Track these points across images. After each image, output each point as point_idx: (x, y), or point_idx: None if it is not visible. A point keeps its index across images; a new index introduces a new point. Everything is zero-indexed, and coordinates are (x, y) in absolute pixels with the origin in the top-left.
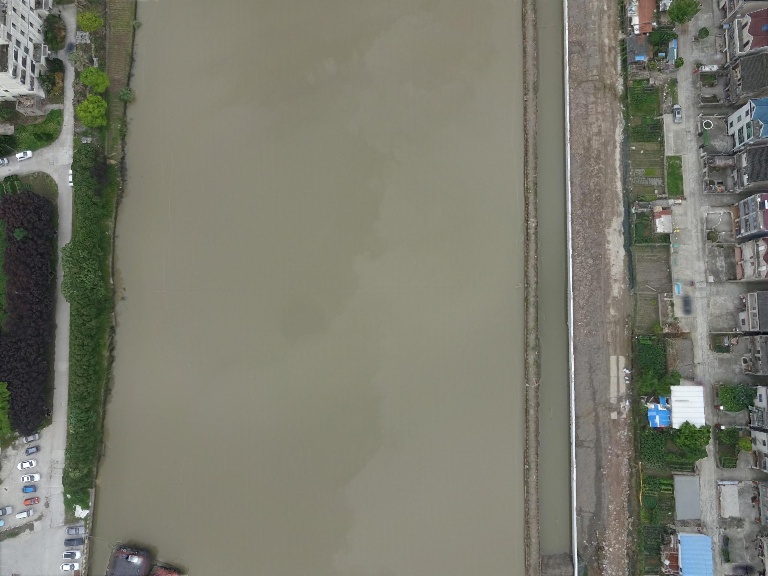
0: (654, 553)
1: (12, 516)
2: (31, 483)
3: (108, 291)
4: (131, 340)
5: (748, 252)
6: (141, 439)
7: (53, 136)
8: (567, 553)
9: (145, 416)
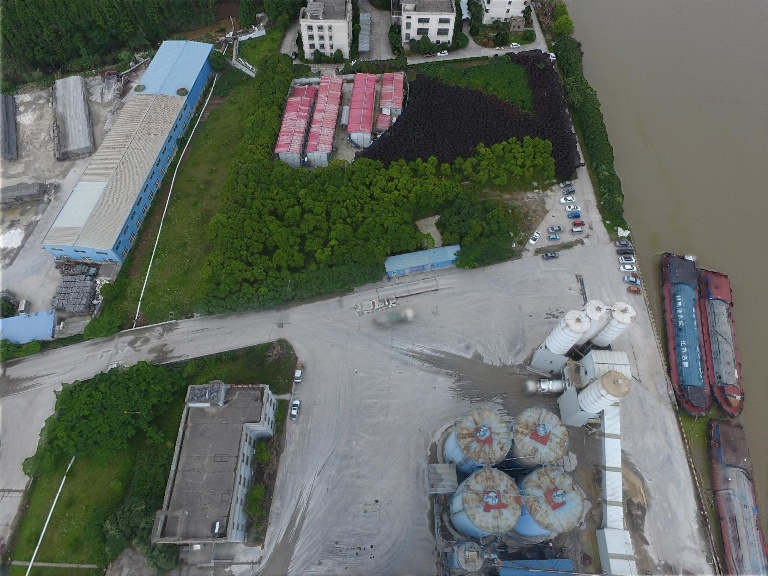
0: None
1: (563, 234)
2: (575, 211)
3: None
4: (616, 140)
5: None
6: (650, 192)
7: (532, 39)
8: None
9: (646, 181)
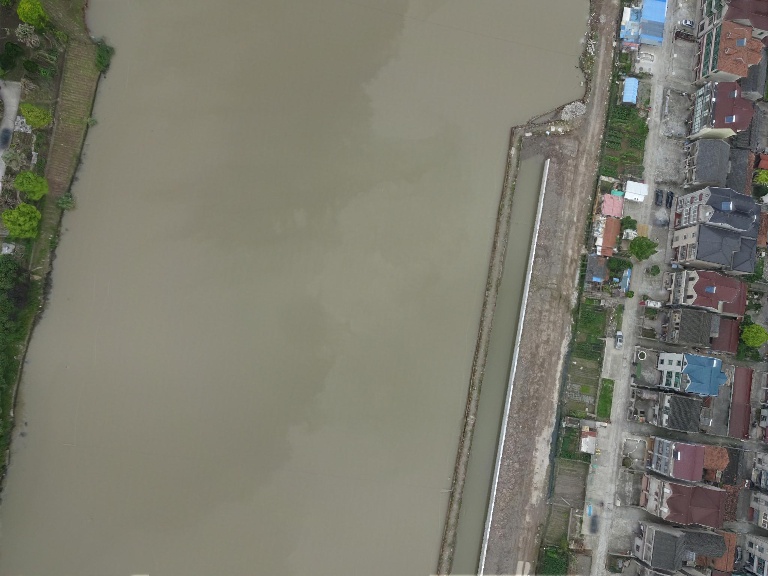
0: None
1: None
2: None
3: (6, 425)
4: (24, 483)
5: (654, 487)
6: None
7: None
8: None
9: (27, 571)
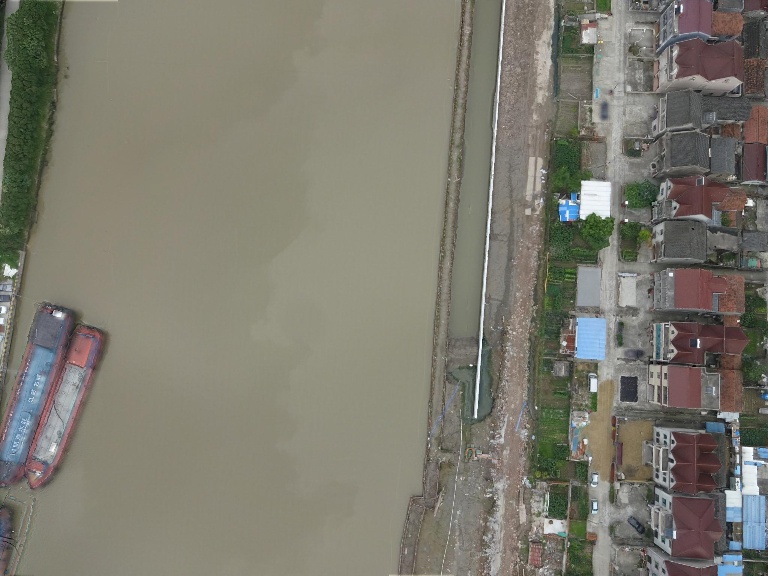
0: (554, 336)
1: None
2: None
3: (51, 67)
4: (71, 117)
5: (664, 62)
6: (74, 208)
7: None
8: (474, 337)
9: (80, 188)
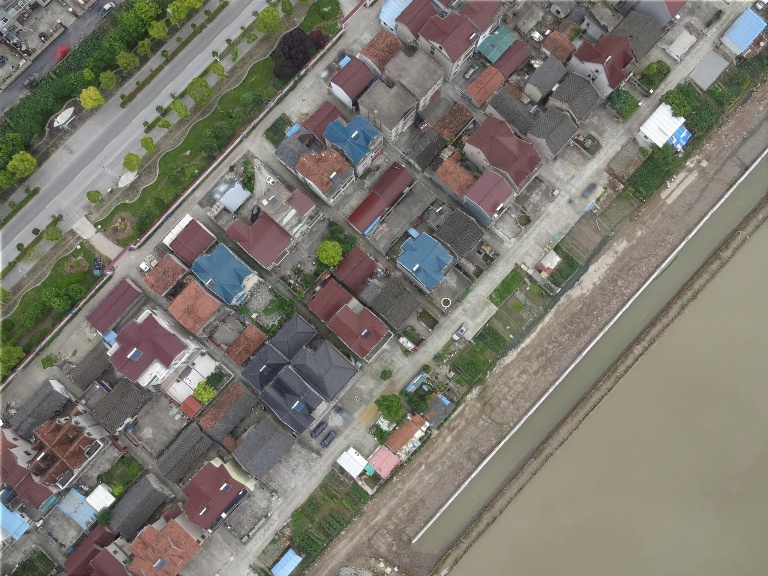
0: (762, 56)
1: None
2: None
3: None
4: None
5: None
6: None
7: None
8: None
9: None
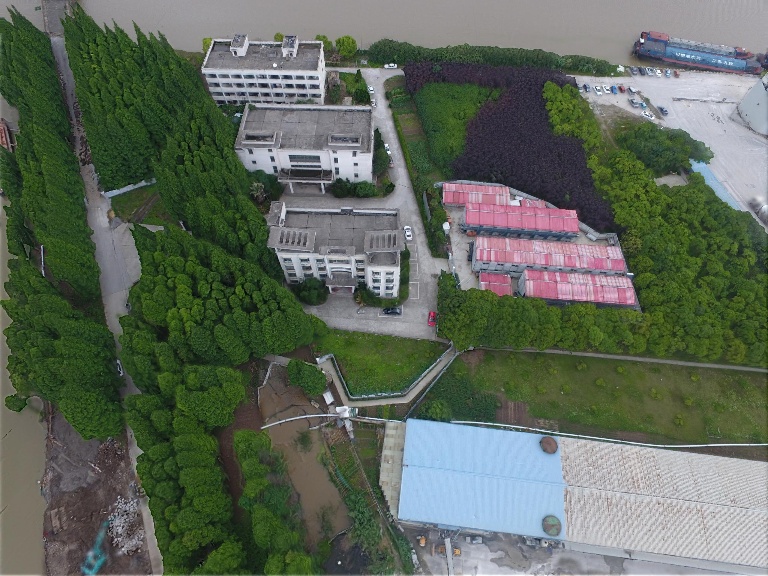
0: None
1: None
2: None
3: None
4: None
5: None
6: (566, 48)
7: None
8: None
9: (551, 48)
